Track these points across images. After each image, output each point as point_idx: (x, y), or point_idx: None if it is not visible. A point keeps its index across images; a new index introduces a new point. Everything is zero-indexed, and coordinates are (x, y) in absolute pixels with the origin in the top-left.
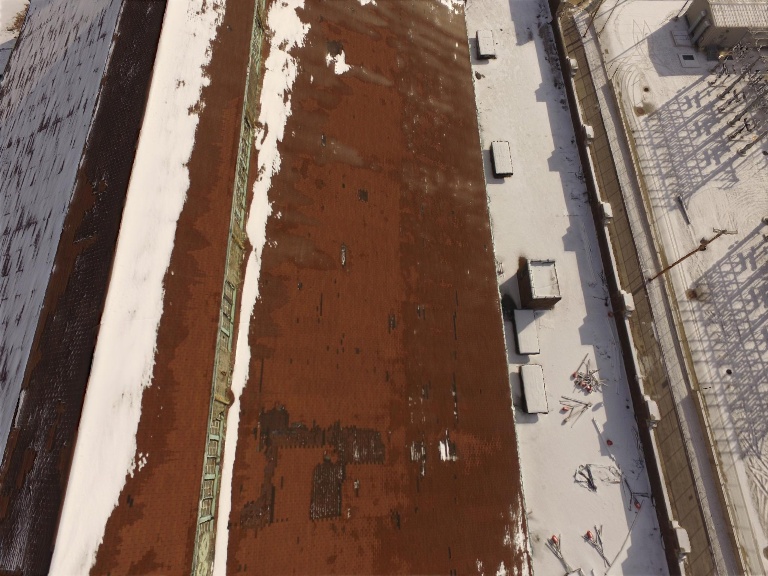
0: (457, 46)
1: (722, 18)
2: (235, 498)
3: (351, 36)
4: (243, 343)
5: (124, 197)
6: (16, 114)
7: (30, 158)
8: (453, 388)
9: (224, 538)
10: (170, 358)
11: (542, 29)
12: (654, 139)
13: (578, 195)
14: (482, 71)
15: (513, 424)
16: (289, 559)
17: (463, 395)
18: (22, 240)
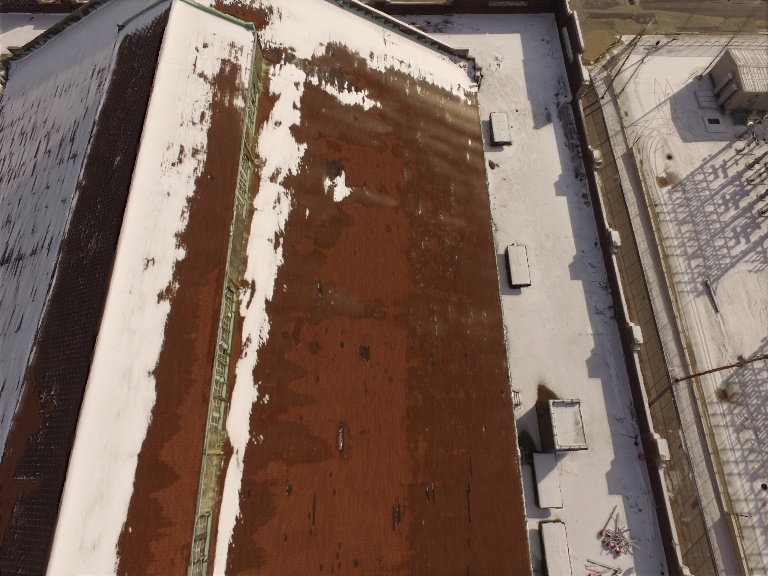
0: (470, 144)
1: (751, 82)
2: None
3: (353, 151)
4: None
5: (73, 433)
6: None
7: None
8: None
9: None
10: None
11: (561, 110)
12: (678, 214)
13: (603, 309)
14: (496, 159)
15: None
16: None
17: None
18: None
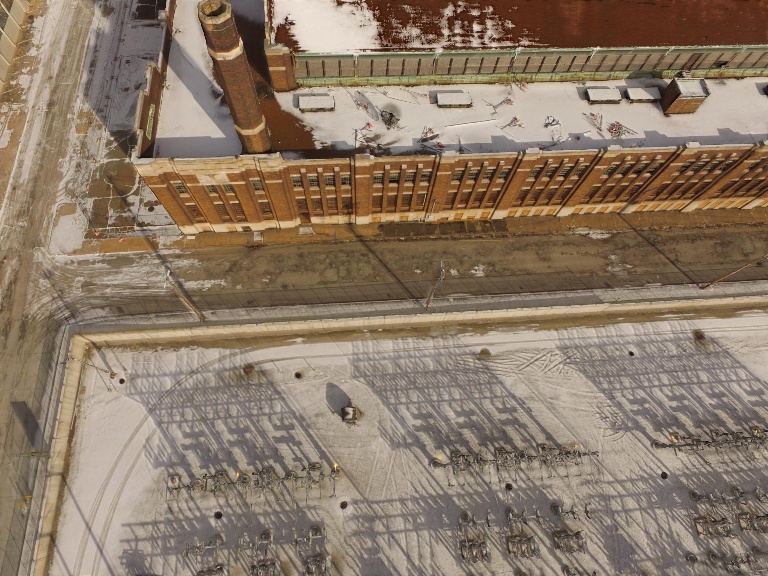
0: None
1: None
2: None
3: None
4: None
5: None
6: None
7: None
8: None
9: None
10: None
11: None
12: None
13: None
14: None
15: (588, 46)
16: None
17: (604, 6)
18: None
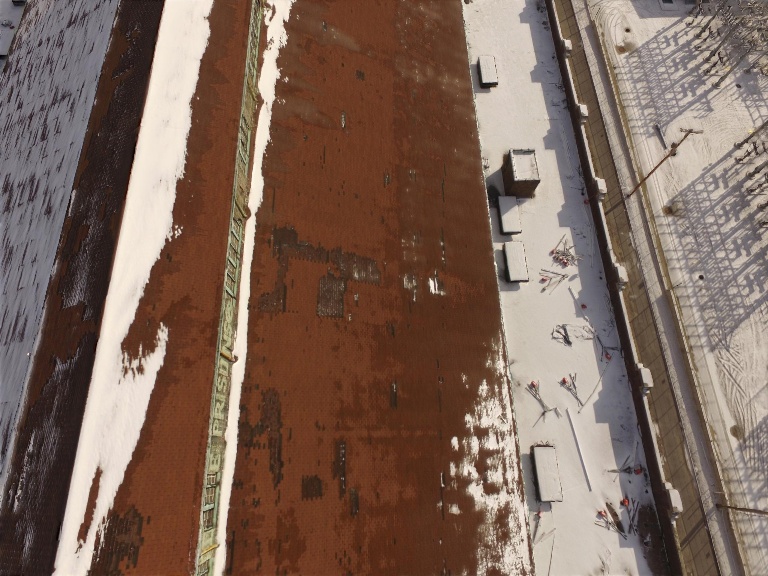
0: None
1: None
2: (253, 288)
3: None
4: (257, 174)
5: (156, 35)
6: (45, 19)
7: (61, 49)
8: (441, 239)
9: (245, 315)
10: (198, 161)
11: None
12: (634, 74)
13: (558, 102)
14: None
15: (495, 277)
16: (299, 341)
17: (450, 246)
18: (58, 110)
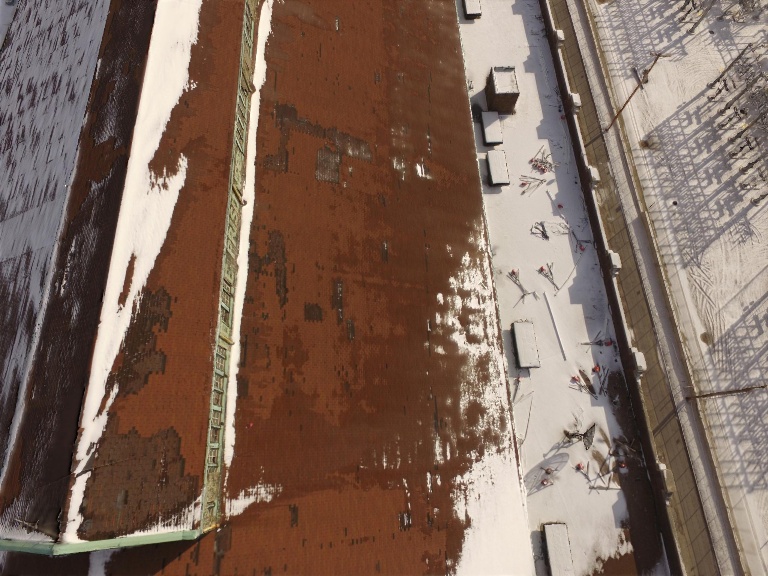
0: None
1: None
2: (259, 149)
3: None
4: (261, 58)
5: None
6: None
7: None
8: (428, 133)
9: (252, 170)
10: (209, 32)
11: None
12: (613, 22)
13: (537, 31)
14: None
15: (477, 171)
16: (300, 197)
17: (436, 140)
18: (76, 18)
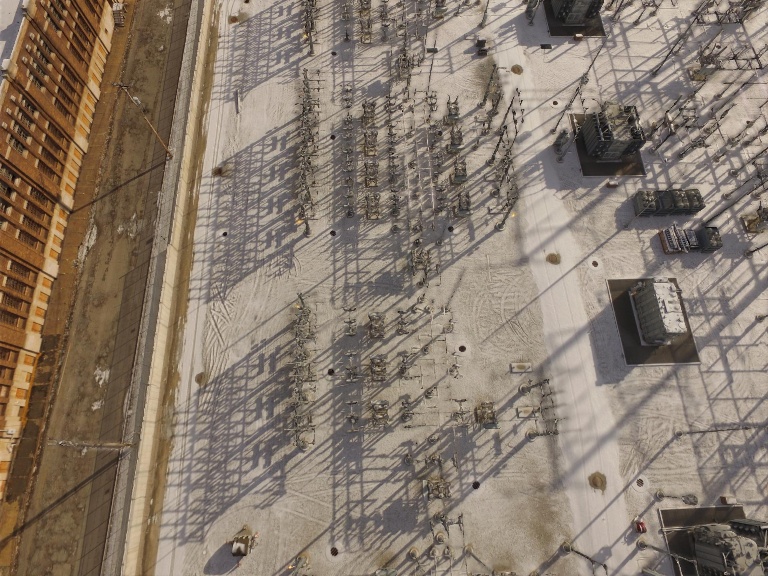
0: None
1: None
2: None
3: None
4: None
5: None
6: None
7: None
8: None
9: None
10: None
11: None
12: (236, 43)
13: None
14: None
15: None
16: None
17: None
18: None
